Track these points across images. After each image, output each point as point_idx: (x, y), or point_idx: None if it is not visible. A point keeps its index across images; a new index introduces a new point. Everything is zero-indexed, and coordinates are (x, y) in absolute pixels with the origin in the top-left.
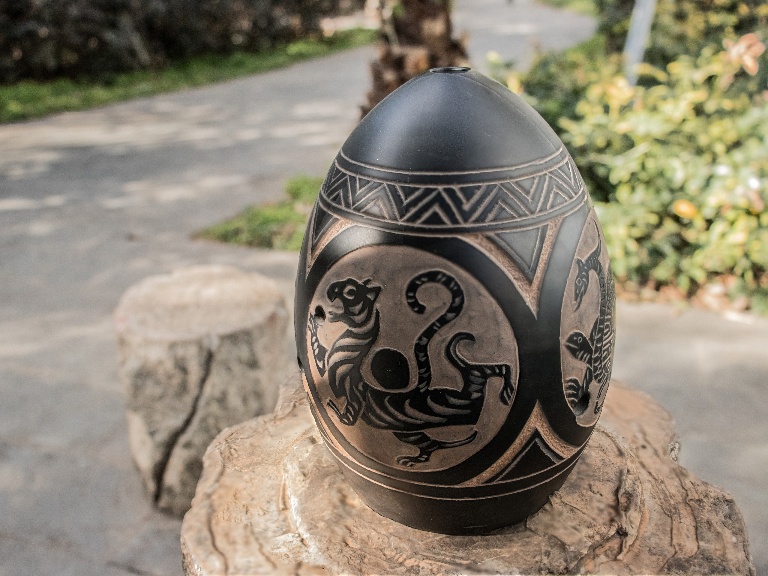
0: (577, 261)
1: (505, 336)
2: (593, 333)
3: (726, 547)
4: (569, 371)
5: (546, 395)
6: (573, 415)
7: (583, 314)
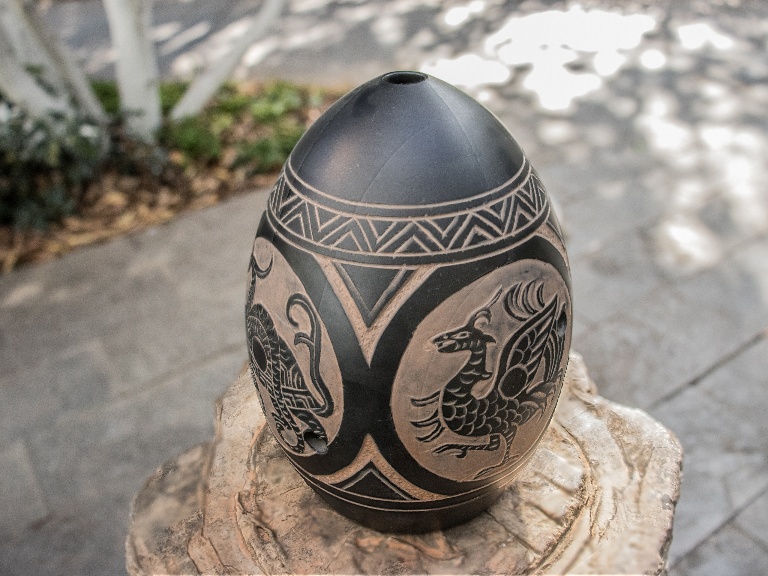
0: None
1: None
2: None
3: (168, 573)
4: None
5: None
6: None
7: None
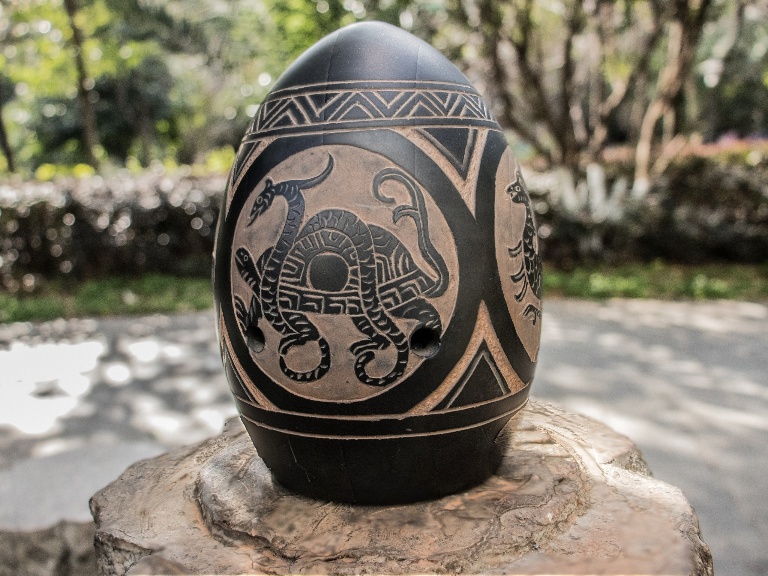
0: (267, 180)
1: (217, 231)
2: (263, 261)
3: None
4: (237, 287)
5: (224, 302)
6: (245, 343)
7: (254, 234)
